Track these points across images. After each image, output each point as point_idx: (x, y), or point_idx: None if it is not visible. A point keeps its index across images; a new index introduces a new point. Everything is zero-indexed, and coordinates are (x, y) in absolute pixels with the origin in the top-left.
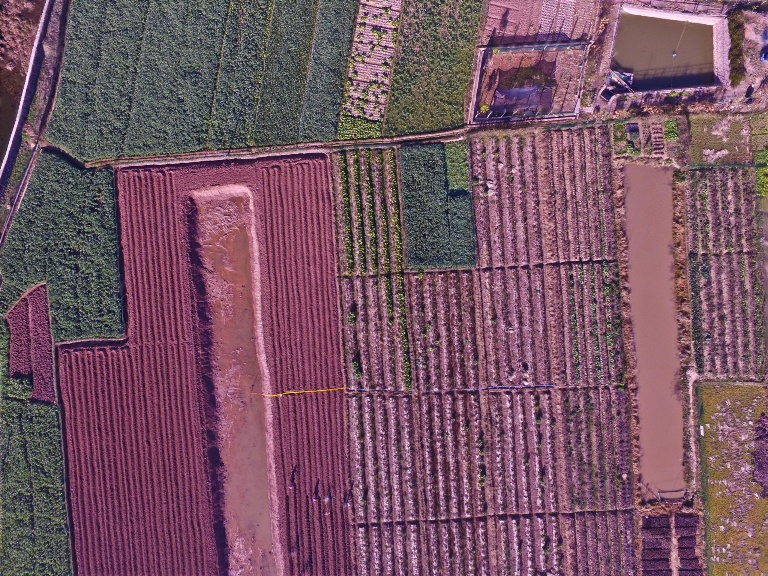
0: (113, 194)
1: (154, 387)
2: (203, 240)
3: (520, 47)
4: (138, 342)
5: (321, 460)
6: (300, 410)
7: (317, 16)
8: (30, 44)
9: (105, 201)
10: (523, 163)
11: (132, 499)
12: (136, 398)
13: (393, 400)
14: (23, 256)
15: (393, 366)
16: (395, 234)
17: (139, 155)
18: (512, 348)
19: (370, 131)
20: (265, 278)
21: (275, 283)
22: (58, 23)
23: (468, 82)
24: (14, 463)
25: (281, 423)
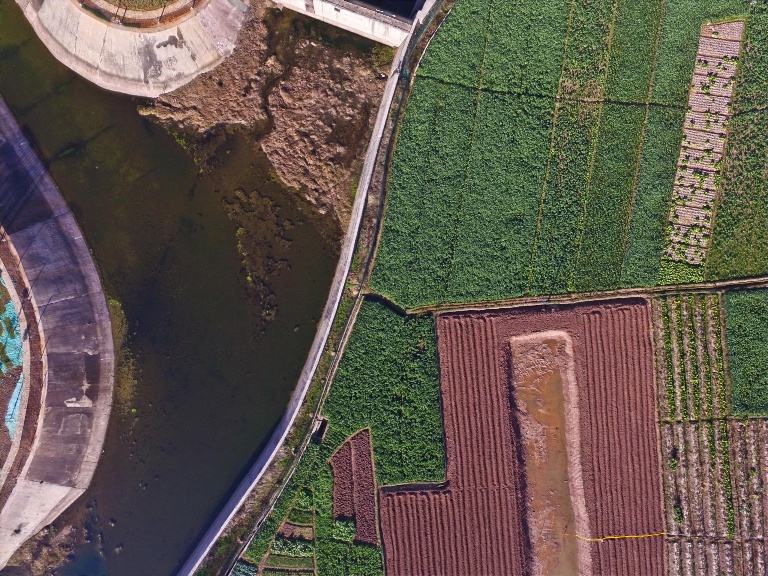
0: (435, 340)
1: (476, 531)
2: (517, 382)
3: None
4: (460, 486)
5: None
6: (621, 555)
7: (640, 161)
8: (343, 188)
9: (427, 348)
10: None
11: None
12: (458, 541)
13: (715, 546)
14: (349, 402)
15: (714, 512)
16: (719, 380)
17: (460, 302)
18: None
19: (693, 276)
20: (586, 424)
21: (597, 429)
22: (382, 173)
23: None
24: None
25: (601, 567)
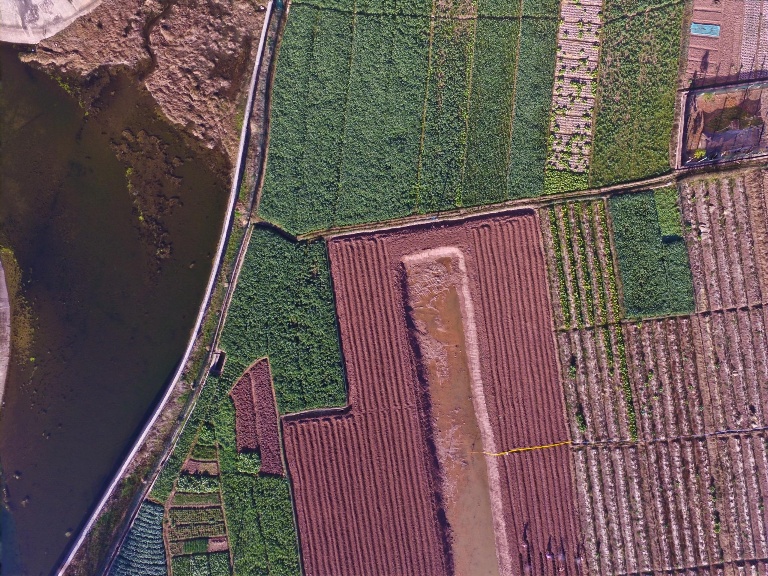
0: (327, 265)
1: (381, 453)
2: (414, 303)
3: (723, 88)
4: (362, 410)
5: (552, 516)
6: (527, 467)
7: (517, 73)
8: (229, 122)
9: (320, 272)
10: (734, 204)
11: (366, 566)
12: (364, 465)
13: (620, 451)
14: (245, 332)
15: (617, 417)
16: (610, 285)
17: (350, 224)
18: (737, 391)
19: (577, 183)
20: (483, 337)
21: (494, 342)
22: (263, 101)
23: (671, 127)
24: (249, 537)
25: (509, 481)
